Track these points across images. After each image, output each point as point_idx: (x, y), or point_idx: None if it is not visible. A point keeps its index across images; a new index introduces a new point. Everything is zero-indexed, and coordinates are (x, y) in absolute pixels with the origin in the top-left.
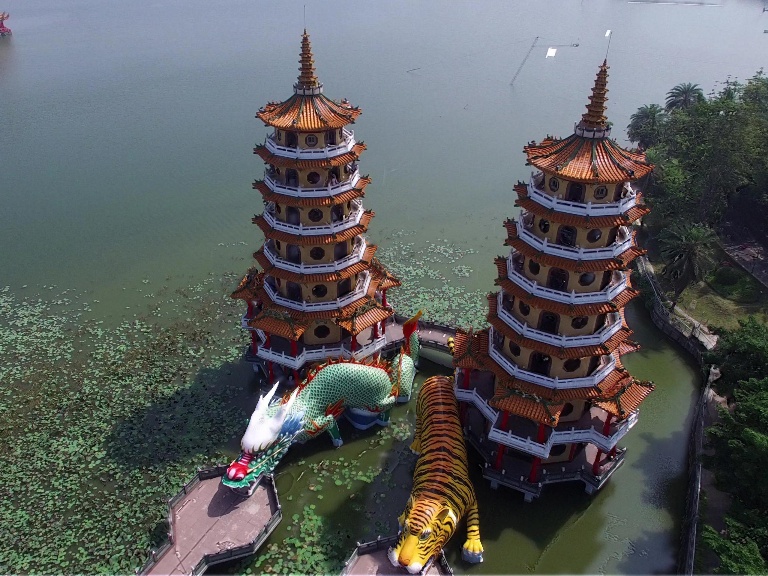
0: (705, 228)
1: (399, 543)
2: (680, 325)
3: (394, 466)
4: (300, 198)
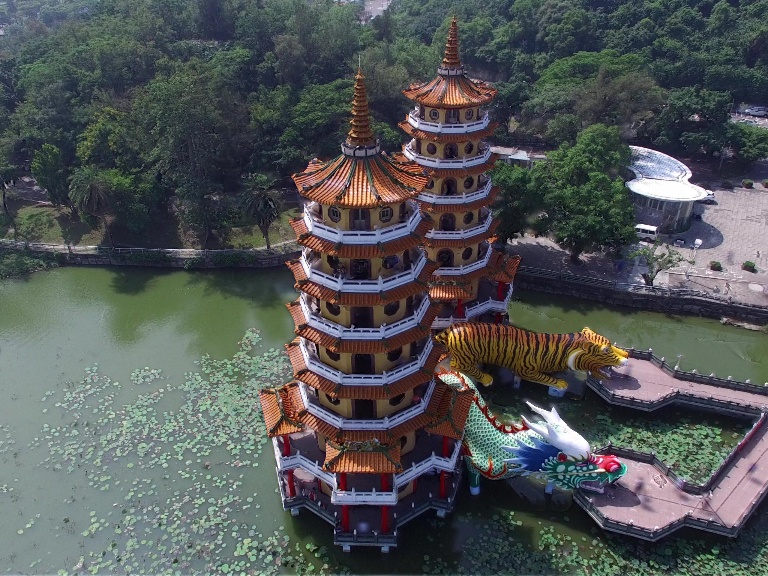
0: None
1: (615, 357)
2: (292, 248)
3: (498, 406)
4: (428, 260)
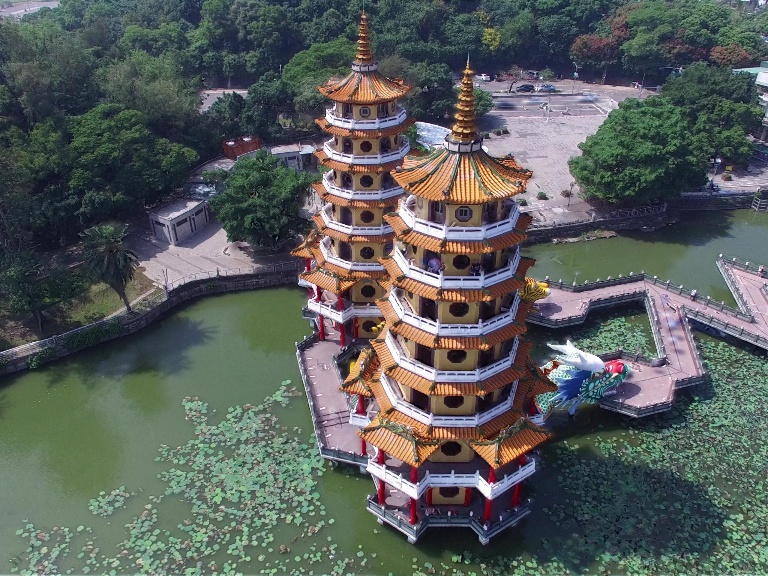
0: (94, 229)
1: None
2: None
3: None
4: None
